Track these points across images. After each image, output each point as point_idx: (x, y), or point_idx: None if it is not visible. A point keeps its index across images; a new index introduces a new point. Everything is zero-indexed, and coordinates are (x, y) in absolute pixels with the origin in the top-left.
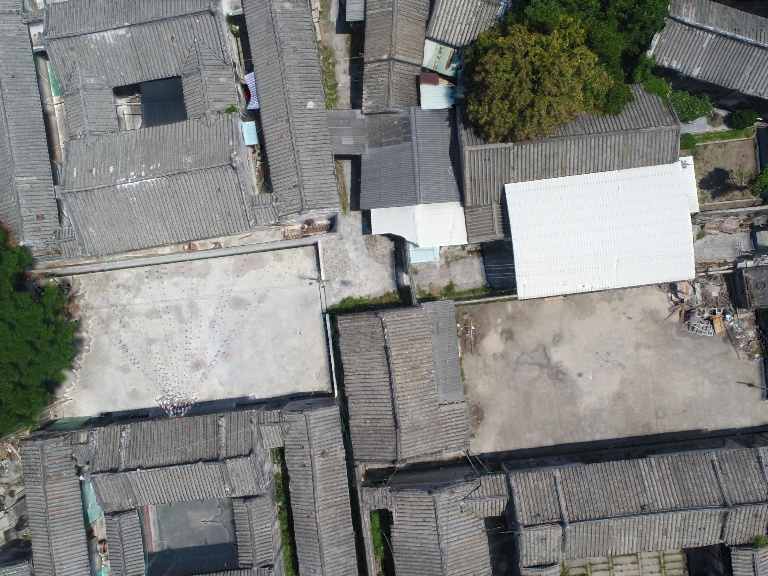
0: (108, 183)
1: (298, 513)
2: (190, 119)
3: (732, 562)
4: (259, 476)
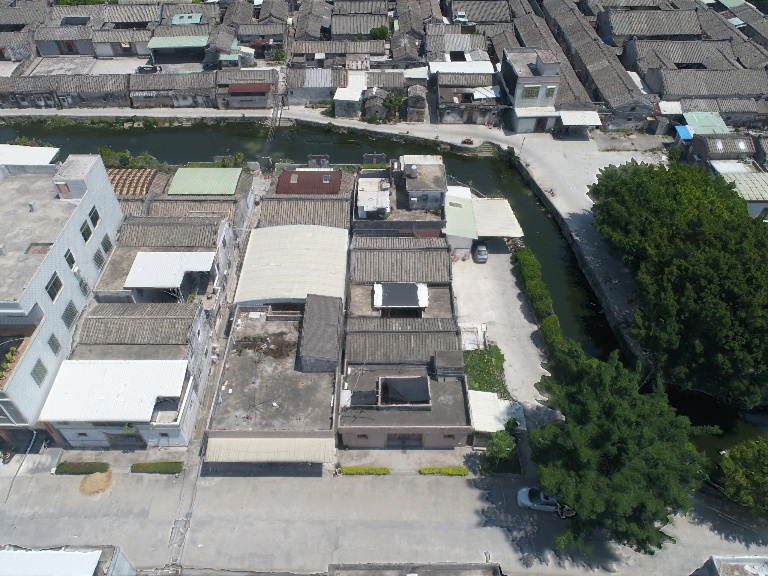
0: None
1: None
2: None
3: (659, 7)
4: None
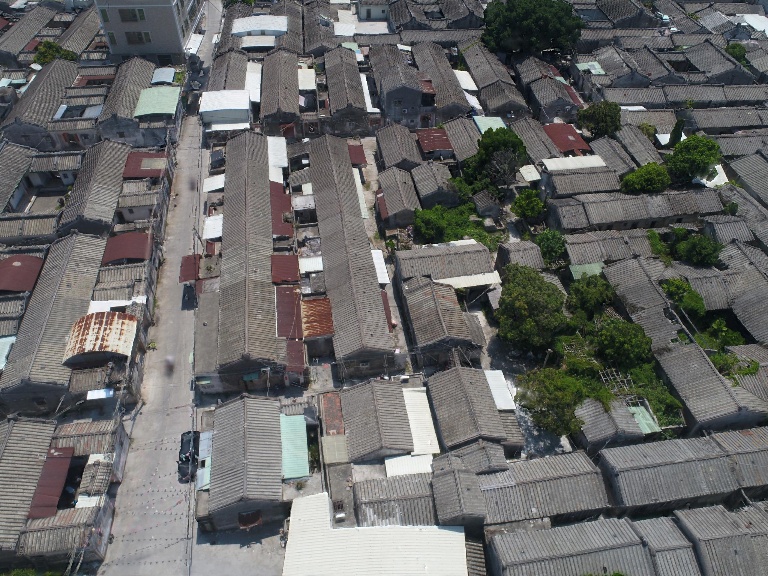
0: (467, 7)
1: (575, 1)
2: (440, 8)
3: None
4: (564, 0)
